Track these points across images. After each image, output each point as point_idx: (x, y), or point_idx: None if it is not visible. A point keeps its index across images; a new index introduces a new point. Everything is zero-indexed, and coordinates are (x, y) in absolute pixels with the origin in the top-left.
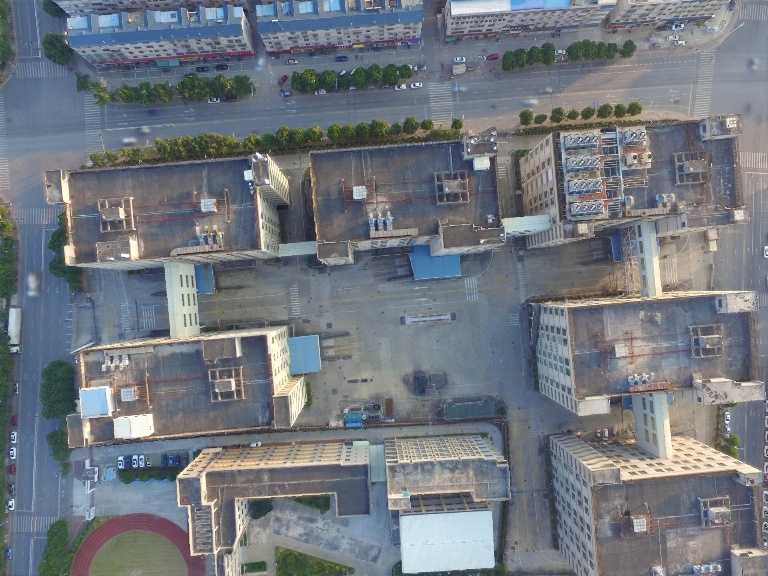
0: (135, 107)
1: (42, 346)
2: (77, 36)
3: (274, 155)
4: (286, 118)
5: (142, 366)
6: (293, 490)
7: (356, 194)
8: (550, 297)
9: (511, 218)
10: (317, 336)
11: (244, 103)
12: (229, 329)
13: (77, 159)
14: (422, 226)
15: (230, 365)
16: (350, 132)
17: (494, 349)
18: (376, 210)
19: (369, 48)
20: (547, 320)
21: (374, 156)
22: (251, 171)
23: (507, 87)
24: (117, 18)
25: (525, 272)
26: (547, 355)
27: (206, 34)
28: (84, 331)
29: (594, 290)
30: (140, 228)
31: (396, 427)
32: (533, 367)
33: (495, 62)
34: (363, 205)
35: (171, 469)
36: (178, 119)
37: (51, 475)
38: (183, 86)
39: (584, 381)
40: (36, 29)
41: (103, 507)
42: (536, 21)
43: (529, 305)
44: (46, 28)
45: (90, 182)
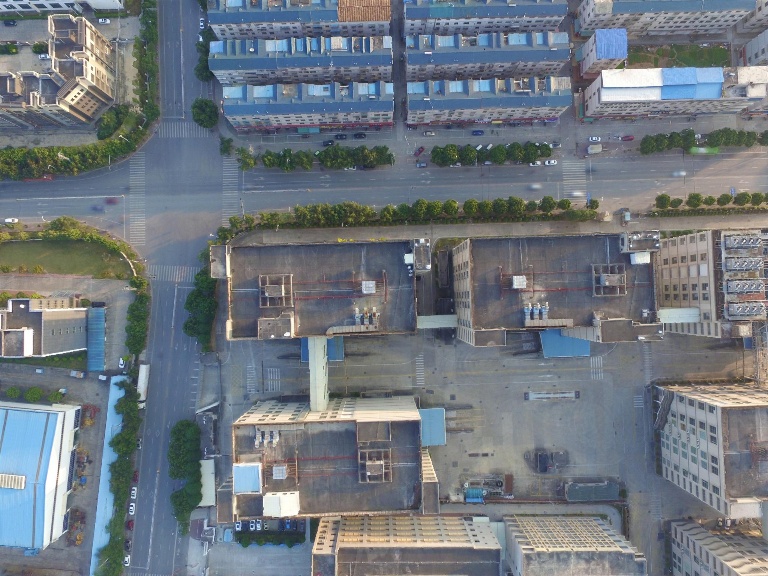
0: (272, 171)
1: (167, 402)
2: (233, 106)
3: (407, 225)
4: (420, 188)
5: (291, 442)
6: (424, 570)
7: (516, 284)
8: (676, 380)
9: (660, 310)
10: (443, 409)
11: (379, 172)
12: (354, 396)
13: (213, 219)
14: (576, 316)
15: (379, 446)
16: (489, 209)
17: (617, 430)
18: (532, 298)
19: (506, 124)
20: (684, 410)
21: (532, 244)
22: (412, 255)
23: (640, 168)
24: (271, 89)
25: (651, 354)
26: (680, 444)
27: (358, 109)
28: (209, 390)
29: (720, 376)
30: (297, 305)
31: (515, 504)
32: (656, 450)
33: (630, 143)
34: (519, 293)
35: (288, 534)
36: (314, 184)
37: (168, 533)
38: (326, 155)
39: (734, 482)
40: (181, 91)
41: (217, 568)
42: (679, 108)
43: (655, 388)
44: (190, 90)
45: (251, 257)
